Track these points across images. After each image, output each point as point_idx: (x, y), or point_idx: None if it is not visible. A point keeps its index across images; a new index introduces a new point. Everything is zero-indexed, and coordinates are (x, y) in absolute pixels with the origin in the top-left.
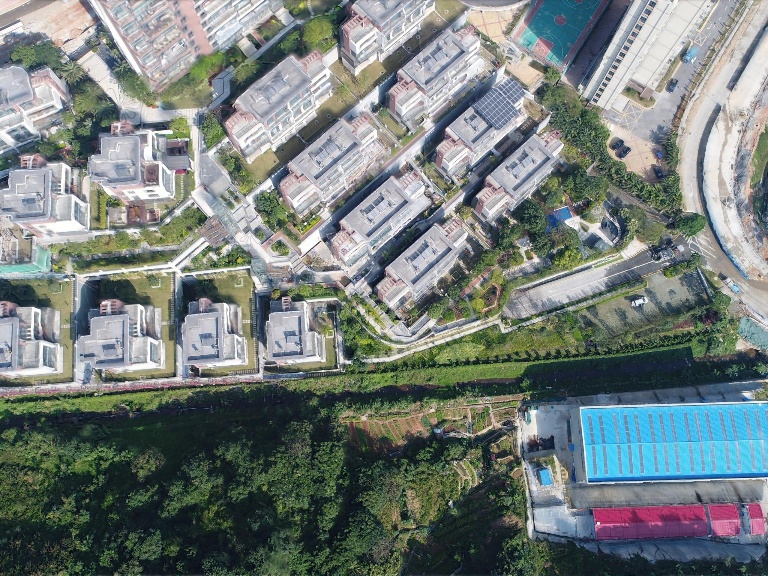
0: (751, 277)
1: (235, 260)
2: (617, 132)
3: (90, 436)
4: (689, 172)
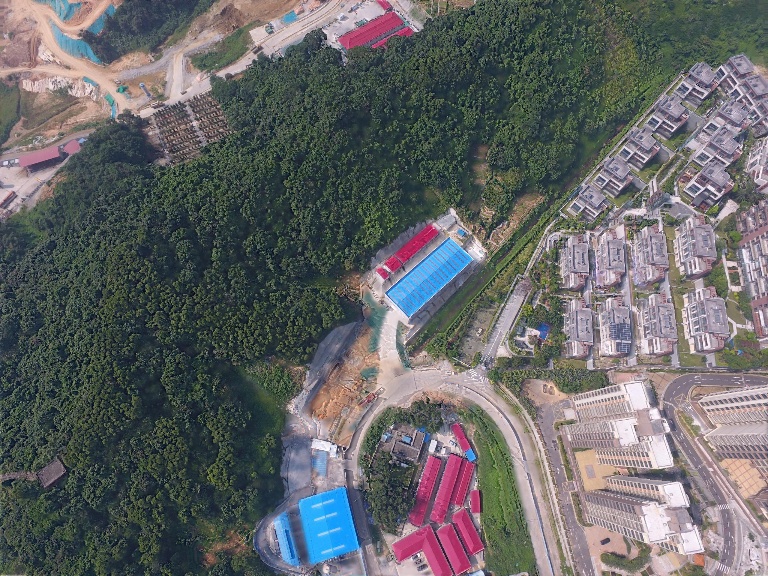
0: (444, 385)
1: (637, 201)
2: (556, 397)
3: (611, 125)
4: (509, 412)
